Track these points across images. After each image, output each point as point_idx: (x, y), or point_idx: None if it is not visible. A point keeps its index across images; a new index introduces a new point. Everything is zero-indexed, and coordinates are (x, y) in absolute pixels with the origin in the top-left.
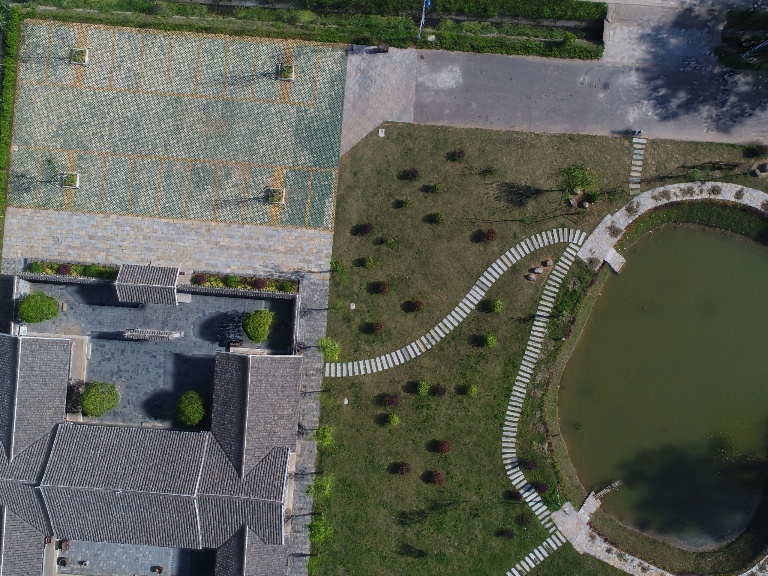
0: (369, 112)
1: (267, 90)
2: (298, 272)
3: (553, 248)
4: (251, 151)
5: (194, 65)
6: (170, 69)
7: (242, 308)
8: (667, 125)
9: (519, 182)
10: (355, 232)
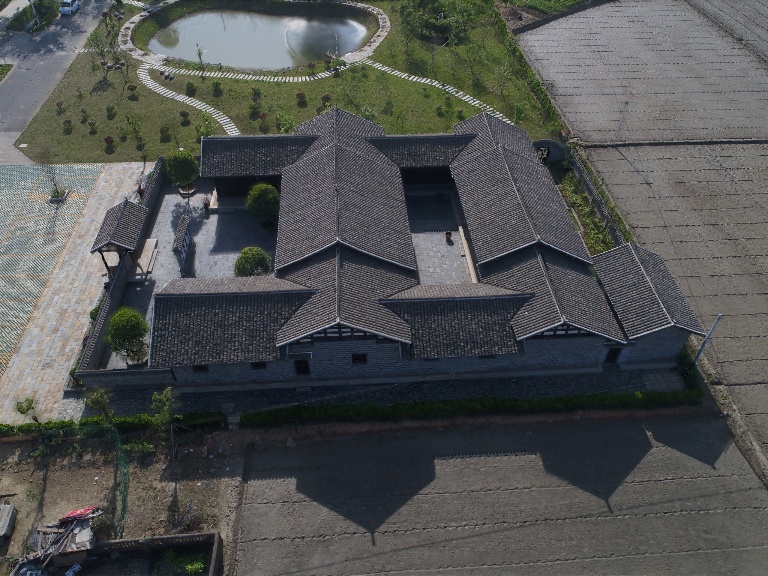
0: (0, 153)
1: None
2: (141, 178)
3: (151, 73)
4: (4, 216)
5: None
6: None
7: (170, 208)
8: (75, 43)
9: (94, 84)
10: (111, 152)
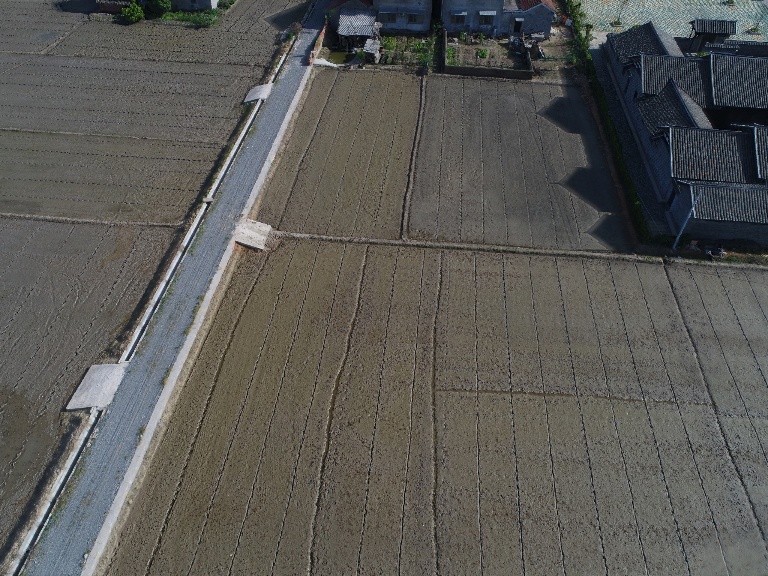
0: None
1: (722, 7)
2: None
3: None
4: None
5: (673, 1)
6: (659, 1)
7: None
8: None
9: None
10: None
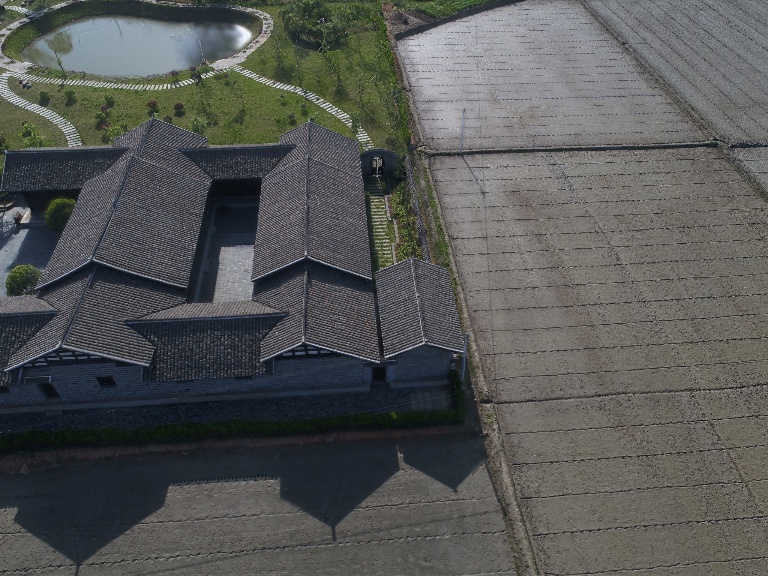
0: None
1: None
2: None
3: (11, 81)
4: None
5: None
6: None
7: None
8: None
9: None
10: None
